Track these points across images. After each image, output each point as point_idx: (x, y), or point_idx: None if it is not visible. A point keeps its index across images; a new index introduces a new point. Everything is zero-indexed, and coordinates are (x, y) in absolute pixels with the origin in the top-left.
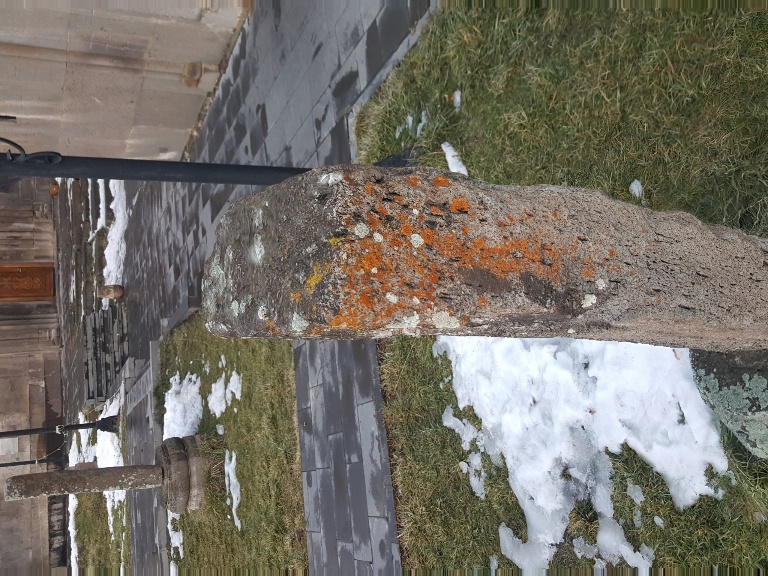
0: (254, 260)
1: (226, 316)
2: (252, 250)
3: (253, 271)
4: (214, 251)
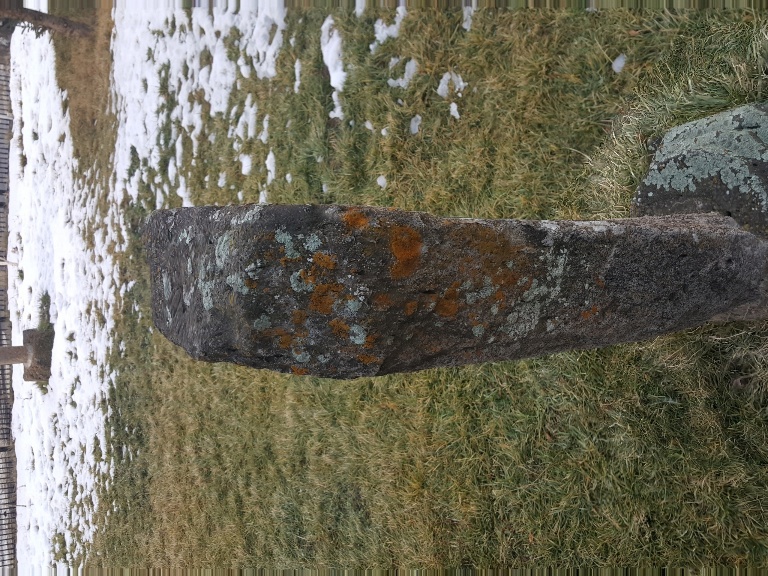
0: (180, 279)
1: (205, 227)
2: (179, 290)
3: (180, 269)
4: (242, 326)
